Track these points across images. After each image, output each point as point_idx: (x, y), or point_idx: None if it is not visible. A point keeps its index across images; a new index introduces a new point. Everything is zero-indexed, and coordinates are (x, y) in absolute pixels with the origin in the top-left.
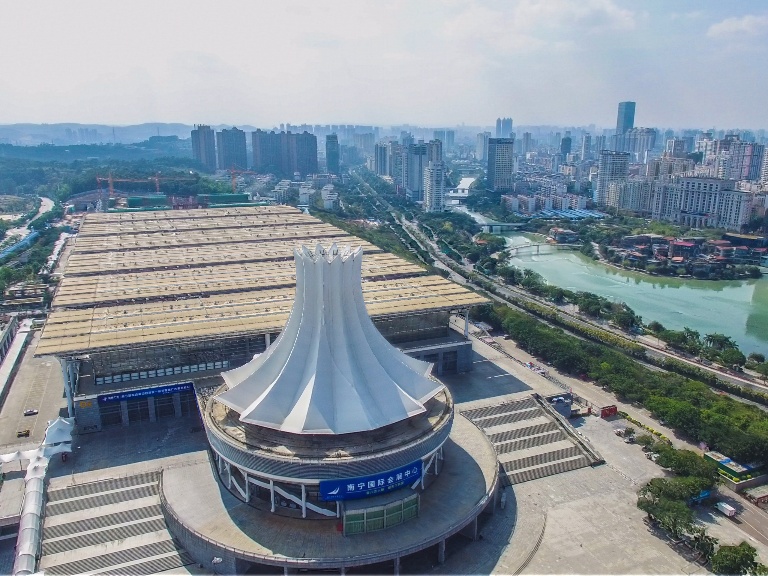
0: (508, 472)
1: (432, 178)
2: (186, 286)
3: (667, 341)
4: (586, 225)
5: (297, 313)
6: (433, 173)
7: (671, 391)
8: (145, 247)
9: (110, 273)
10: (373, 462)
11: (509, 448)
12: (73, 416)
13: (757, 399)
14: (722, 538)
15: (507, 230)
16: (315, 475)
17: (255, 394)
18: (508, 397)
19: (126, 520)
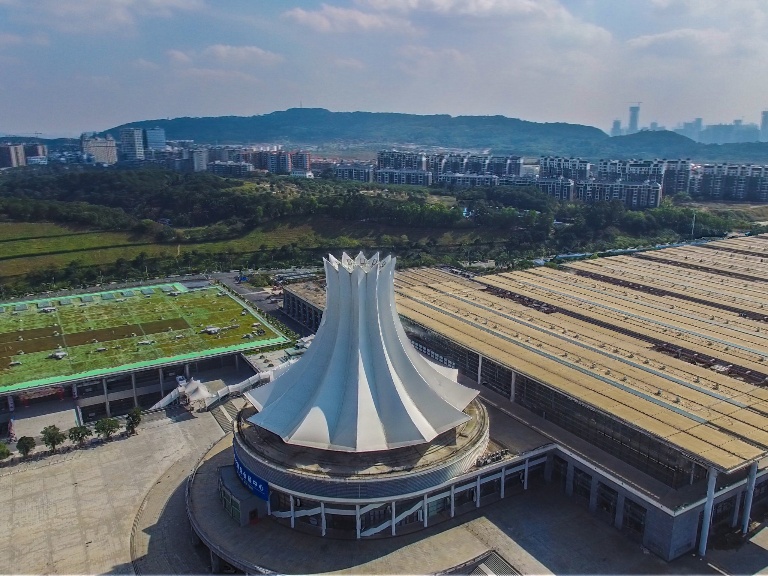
0: None
1: None
2: (567, 299)
3: None
4: None
5: None
6: None
7: None
8: (697, 265)
9: (586, 274)
10: None
11: None
12: None
13: None
14: None
15: None
16: None
17: None
18: None
19: None
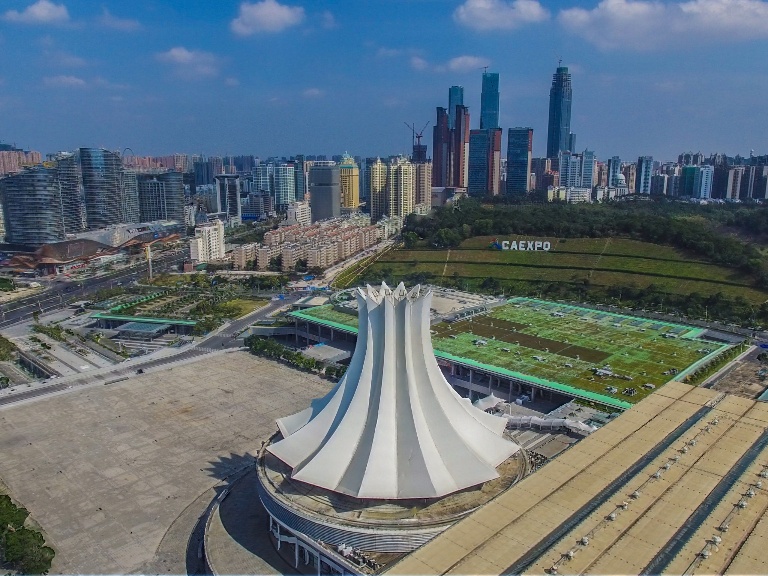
0: None
1: None
2: None
3: None
4: None
5: None
6: None
7: None
8: None
9: None
10: None
11: None
12: None
13: None
14: None
15: None
16: None
17: None
18: None
19: None
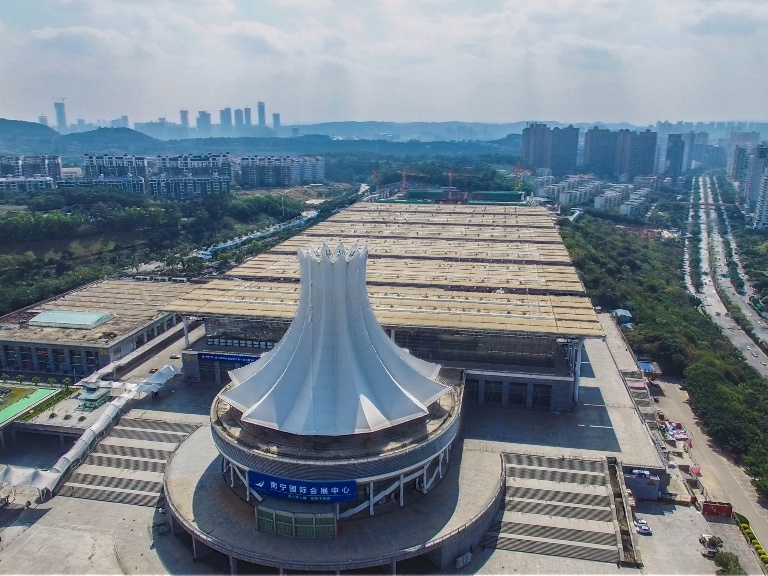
0: (503, 533)
1: (765, 187)
2: None
3: None
4: None
5: None
6: (767, 181)
7: None
8: (358, 235)
9: None
10: (295, 467)
11: (528, 508)
12: None
13: None
14: None
15: None
16: (246, 462)
17: None
18: (577, 452)
19: (149, 456)
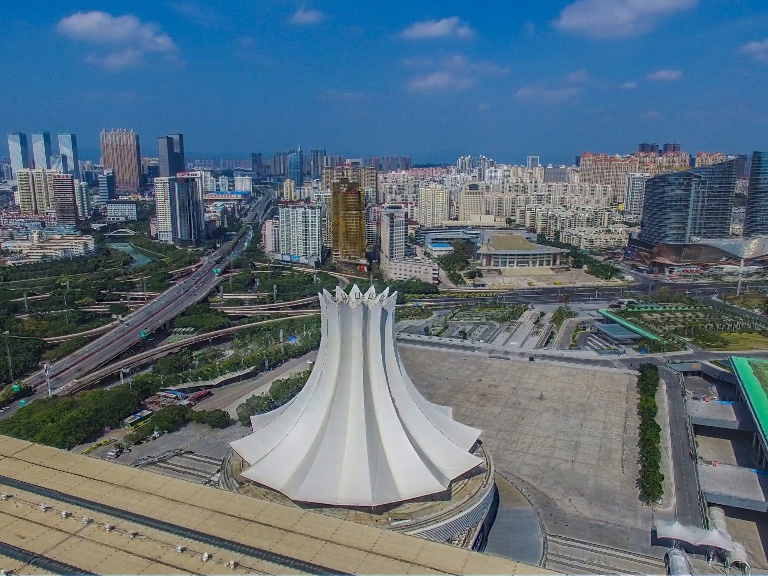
0: None
1: None
2: None
3: None
4: None
5: None
6: None
7: None
8: None
9: None
10: None
11: None
12: None
13: None
14: (236, 413)
15: None
16: None
17: None
18: None
19: (585, 567)
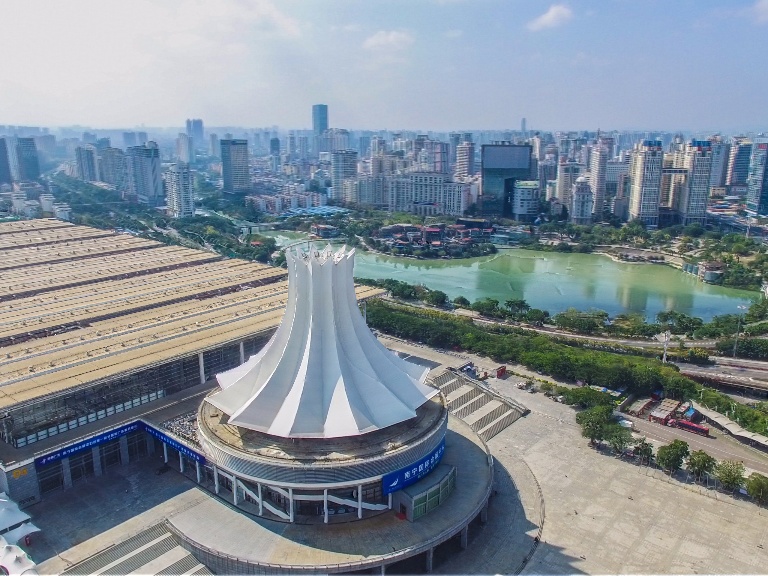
0: None
1: (179, 182)
2: (47, 318)
3: (481, 311)
4: (339, 220)
5: (299, 319)
6: (179, 176)
7: (529, 347)
8: None
9: None
10: (422, 446)
11: None
12: (0, 492)
13: (572, 344)
14: None
15: (265, 230)
16: (378, 471)
17: (273, 410)
18: (429, 375)
19: None
